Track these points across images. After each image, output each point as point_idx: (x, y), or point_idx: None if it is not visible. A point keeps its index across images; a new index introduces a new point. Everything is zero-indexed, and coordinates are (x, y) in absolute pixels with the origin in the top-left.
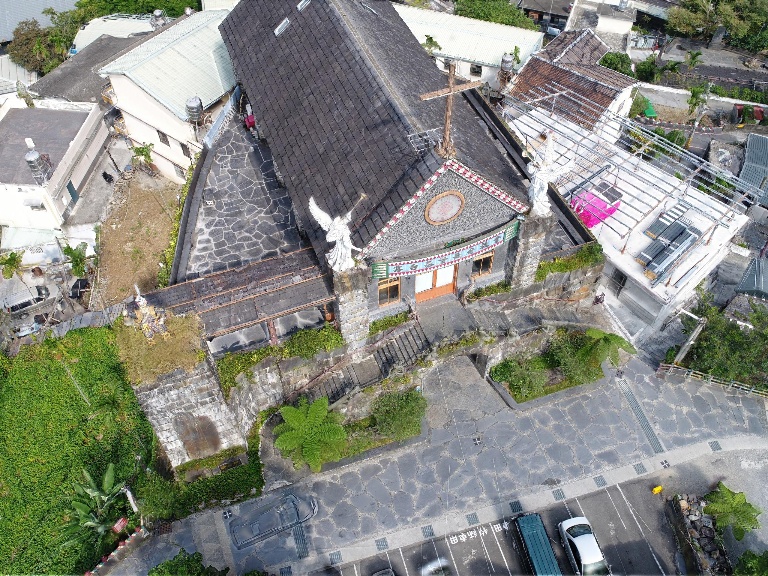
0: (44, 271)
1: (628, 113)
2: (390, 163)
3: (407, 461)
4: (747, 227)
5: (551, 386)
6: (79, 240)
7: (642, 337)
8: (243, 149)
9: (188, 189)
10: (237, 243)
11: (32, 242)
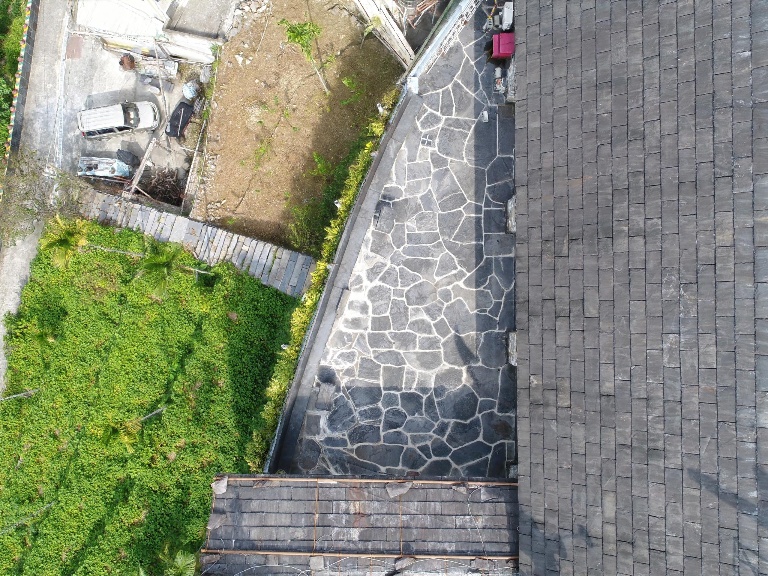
0: (137, 61)
1: None
2: (724, 570)
3: None
4: None
5: None
6: (188, 50)
7: None
8: (470, 108)
9: (356, 186)
10: (406, 331)
11: (121, 27)
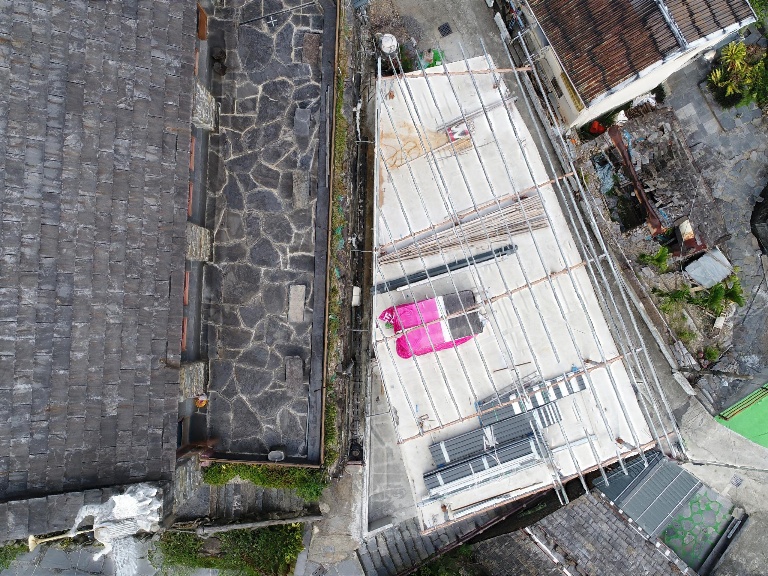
0: None
1: (717, 42)
2: None
3: (3, 573)
4: (759, 310)
5: (218, 559)
6: None
7: (399, 517)
8: None
9: None
10: None
11: None
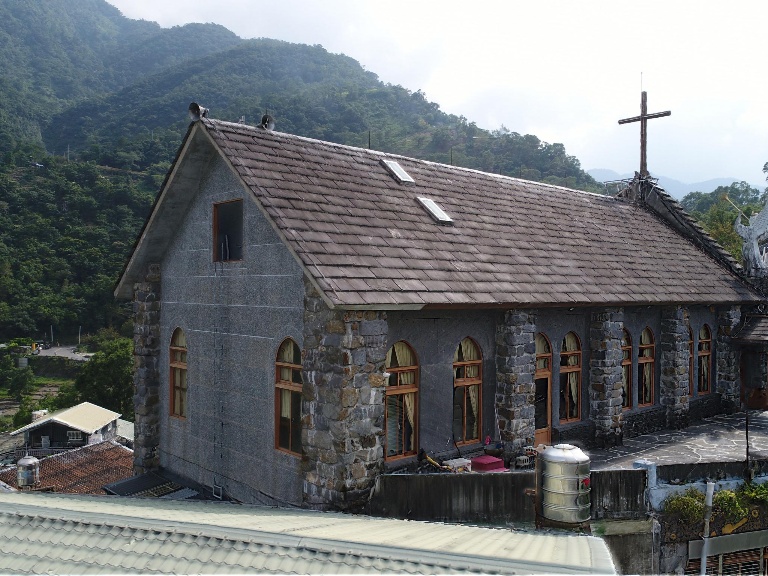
0: None
1: None
2: None
3: None
4: None
5: None
6: None
7: None
8: None
9: None
10: None
11: None
